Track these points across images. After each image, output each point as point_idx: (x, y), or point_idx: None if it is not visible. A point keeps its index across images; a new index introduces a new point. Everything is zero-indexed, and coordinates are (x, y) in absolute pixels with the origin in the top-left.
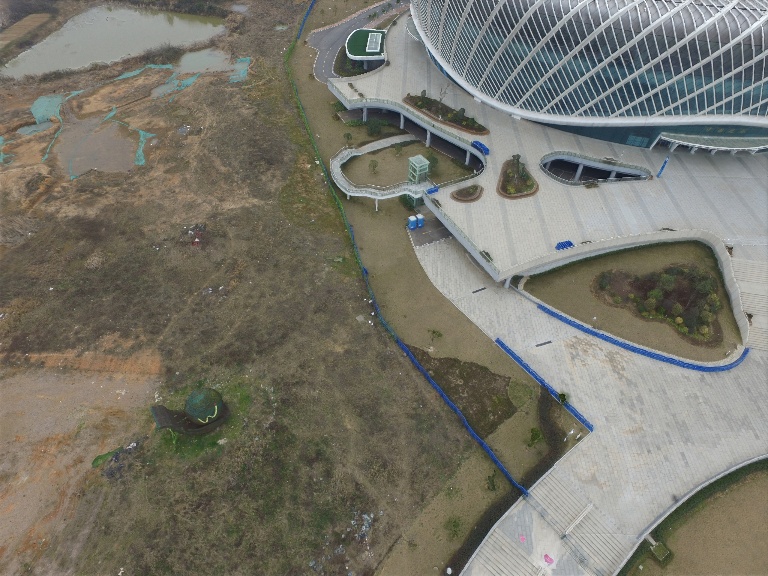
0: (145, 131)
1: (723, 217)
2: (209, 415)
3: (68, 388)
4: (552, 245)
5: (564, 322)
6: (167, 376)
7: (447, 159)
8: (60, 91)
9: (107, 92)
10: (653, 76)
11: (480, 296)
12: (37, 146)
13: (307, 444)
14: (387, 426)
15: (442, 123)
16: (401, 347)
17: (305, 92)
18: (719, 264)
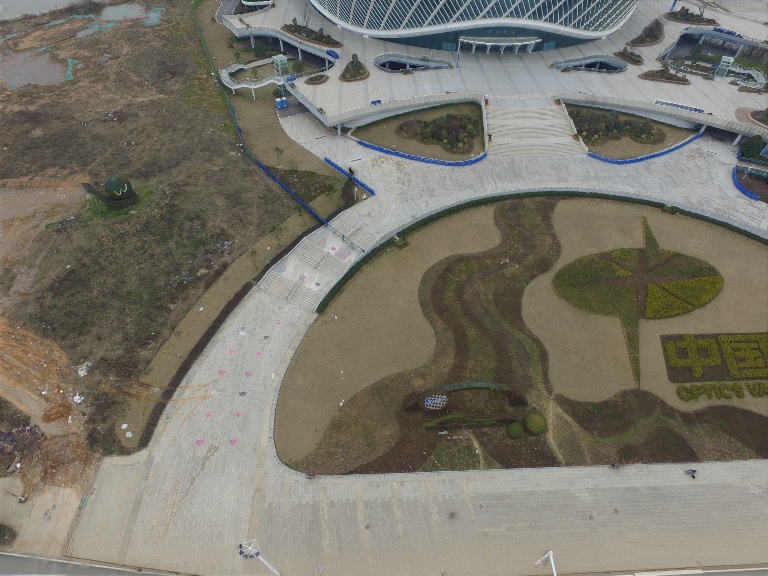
0: (72, 59)
1: (492, 86)
2: (121, 189)
3: (24, 196)
4: (369, 104)
5: (373, 149)
6: (95, 187)
7: (314, 69)
8: None
9: (38, 34)
10: None
11: (320, 140)
12: None
13: (190, 212)
14: (245, 203)
15: (308, 41)
16: (259, 166)
17: (207, 31)
18: None
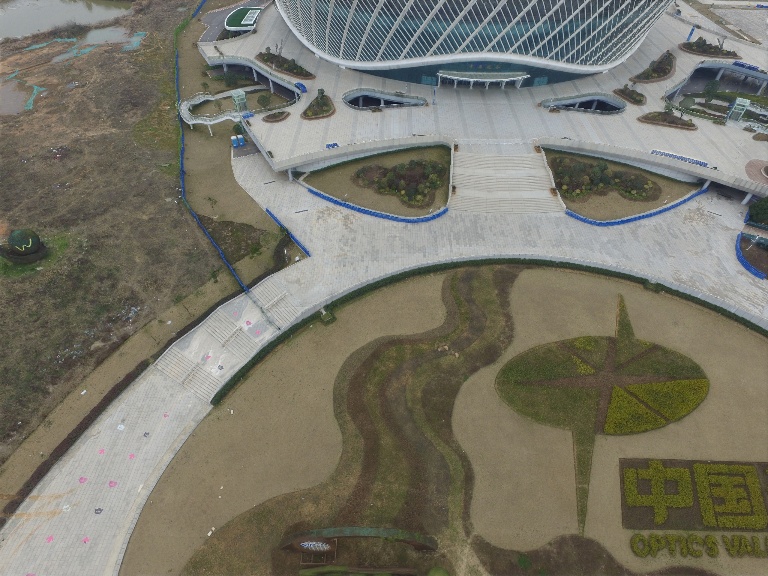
0: (39, 86)
1: (467, 128)
2: (24, 244)
3: None
4: (325, 147)
5: (323, 199)
6: None
7: (284, 101)
8: None
9: (14, 59)
10: (410, 21)
11: (268, 186)
12: None
13: (102, 270)
14: (166, 260)
15: (279, 72)
16: (193, 215)
17: (185, 57)
18: None
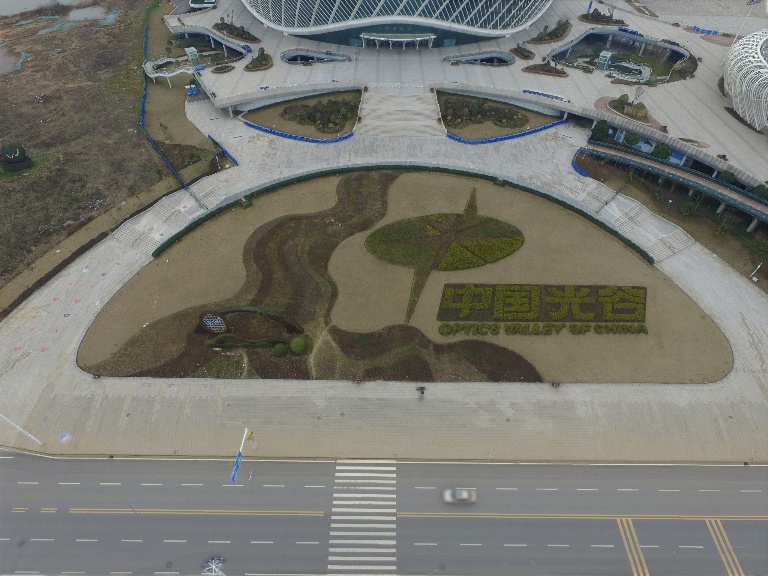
0: (26, 52)
1: (379, 77)
2: (13, 153)
3: None
4: None
5: (255, 129)
6: None
7: None
8: None
9: (4, 32)
10: None
11: (213, 121)
12: None
13: (75, 175)
14: (125, 170)
15: (231, 38)
16: (149, 140)
17: (154, 30)
18: None
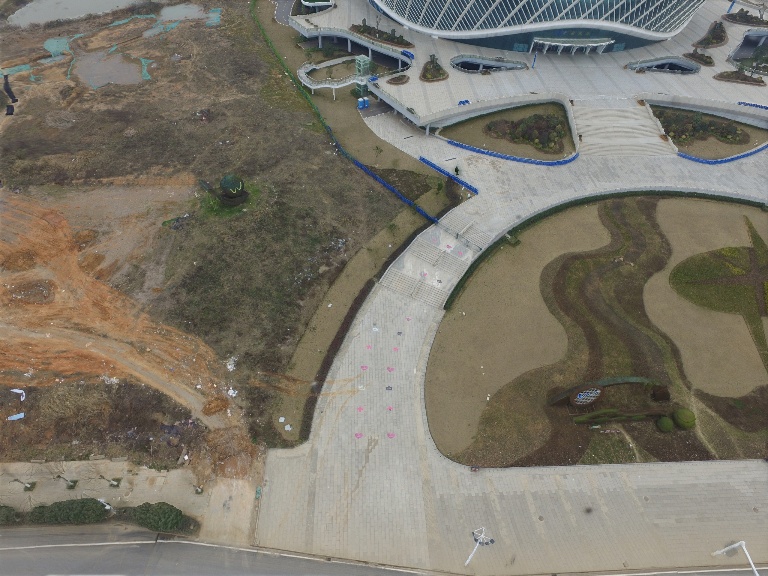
0: (145, 59)
1: (572, 87)
2: (237, 187)
3: (134, 194)
4: (456, 104)
5: (464, 149)
6: (201, 185)
7: (385, 69)
8: (64, 35)
9: (105, 34)
10: None
11: (409, 140)
12: (59, 70)
13: (300, 210)
14: (350, 201)
15: (379, 42)
16: (357, 165)
17: (270, 31)
18: (567, 113)
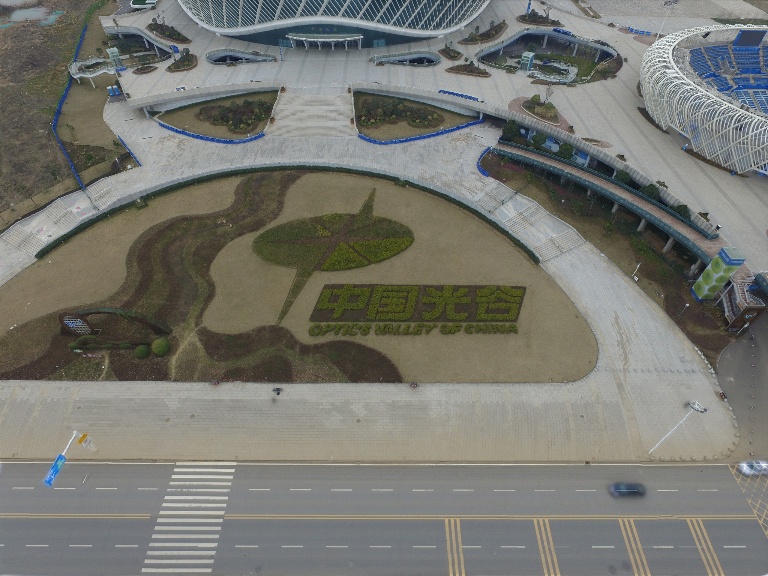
0: None
1: (301, 77)
2: None
3: None
4: None
5: (168, 129)
6: None
7: None
8: None
9: None
10: None
11: (128, 122)
12: None
13: None
14: (27, 171)
15: (162, 38)
16: (58, 141)
17: (92, 30)
18: None
